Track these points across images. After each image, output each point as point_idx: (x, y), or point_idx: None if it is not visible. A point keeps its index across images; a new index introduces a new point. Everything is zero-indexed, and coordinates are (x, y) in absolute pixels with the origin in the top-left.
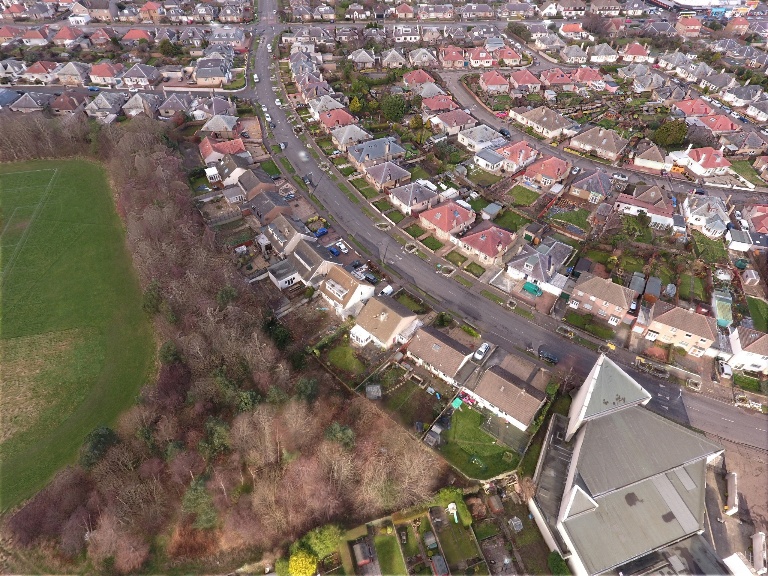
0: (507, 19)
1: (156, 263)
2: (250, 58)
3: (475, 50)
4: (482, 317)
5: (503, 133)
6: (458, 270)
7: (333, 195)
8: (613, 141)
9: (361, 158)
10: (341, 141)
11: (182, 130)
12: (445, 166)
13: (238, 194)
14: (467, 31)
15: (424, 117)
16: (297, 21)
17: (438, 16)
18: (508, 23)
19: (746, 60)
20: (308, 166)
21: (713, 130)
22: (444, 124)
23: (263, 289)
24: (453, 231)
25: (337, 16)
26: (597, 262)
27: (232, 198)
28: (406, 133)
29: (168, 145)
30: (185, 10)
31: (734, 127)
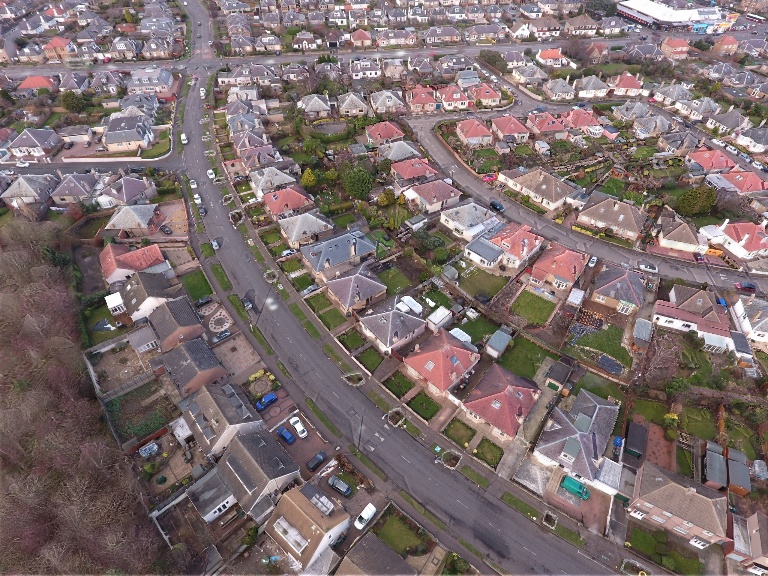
0: (476, 44)
1: (0, 519)
2: (178, 108)
3: (447, 90)
4: (510, 551)
5: (495, 207)
6: (465, 456)
7: (284, 326)
8: (632, 217)
9: (319, 265)
10: (292, 237)
11: (81, 226)
12: (429, 267)
13: (149, 340)
14: (434, 60)
15: (396, 190)
16: (236, 55)
17: (399, 42)
18: (480, 51)
19: (747, 89)
20: (249, 276)
21: (742, 191)
22: (422, 200)
23: (181, 523)
24: (452, 385)
25: (283, 47)
26: (650, 422)
27: (141, 347)
28: (375, 217)
29: (54, 261)
30: (102, 44)
31: (765, 186)
